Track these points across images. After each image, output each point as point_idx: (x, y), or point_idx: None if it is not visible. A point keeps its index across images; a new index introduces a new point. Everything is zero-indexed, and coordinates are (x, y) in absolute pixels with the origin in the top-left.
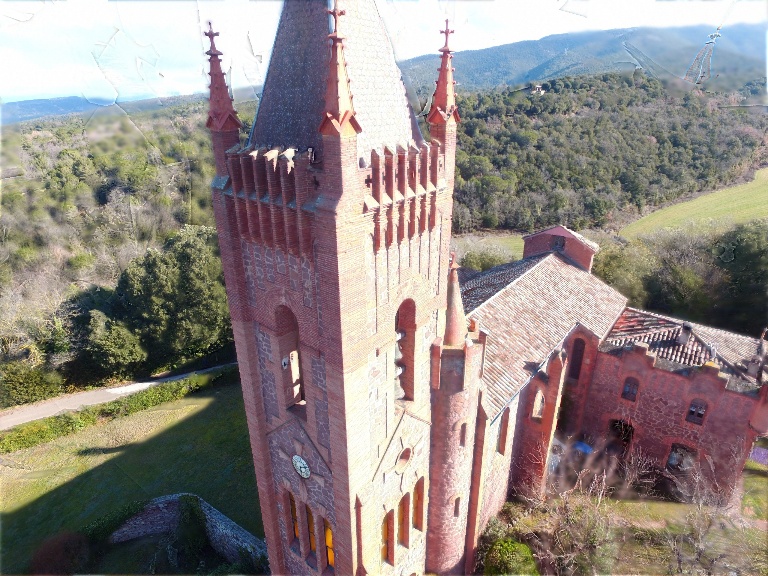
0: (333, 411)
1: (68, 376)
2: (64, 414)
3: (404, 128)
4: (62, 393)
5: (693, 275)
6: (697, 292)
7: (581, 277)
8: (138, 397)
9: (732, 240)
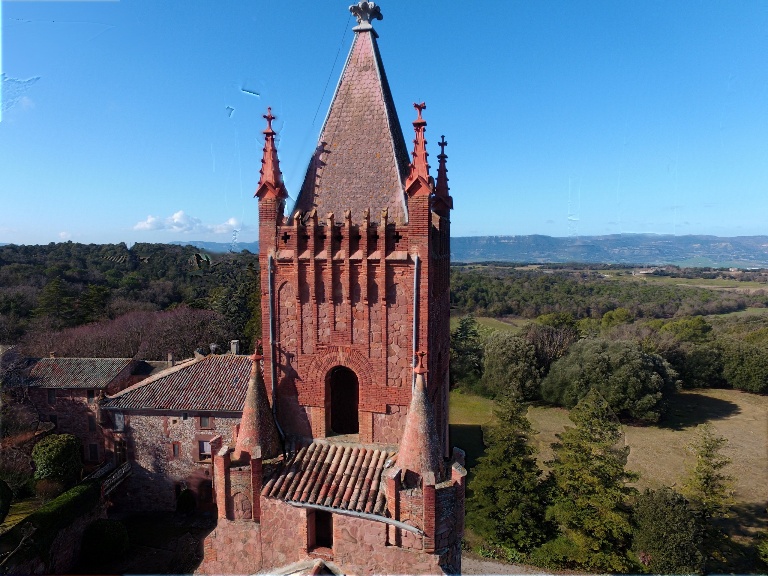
0: None
1: None
2: None
3: None
4: None
5: None
6: None
7: None
8: None
9: None
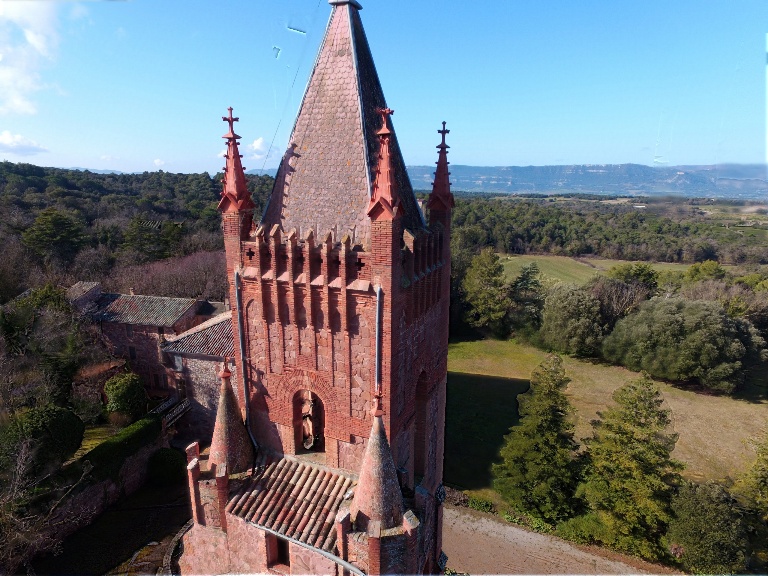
0: None
1: None
2: None
3: None
4: None
5: None
6: None
7: None
8: None
9: None
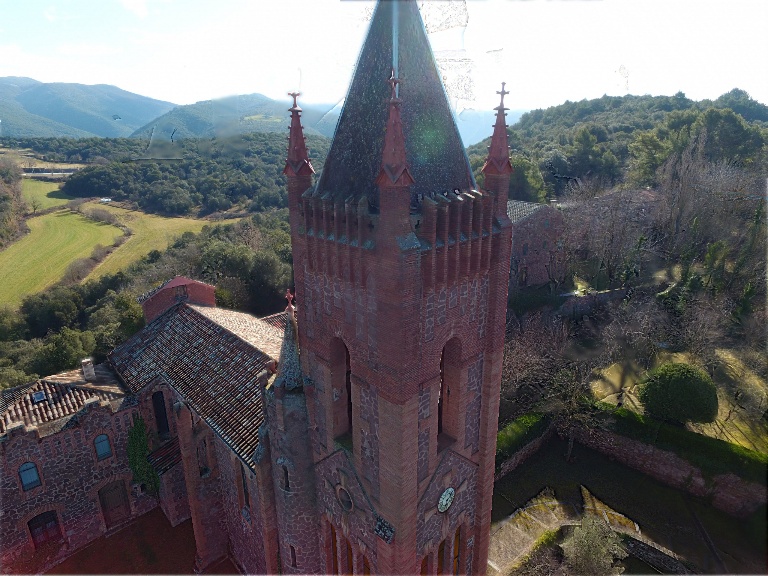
0: (493, 391)
1: None
2: None
3: None
4: None
5: (224, 290)
6: (236, 300)
7: (221, 312)
8: None
9: (208, 260)
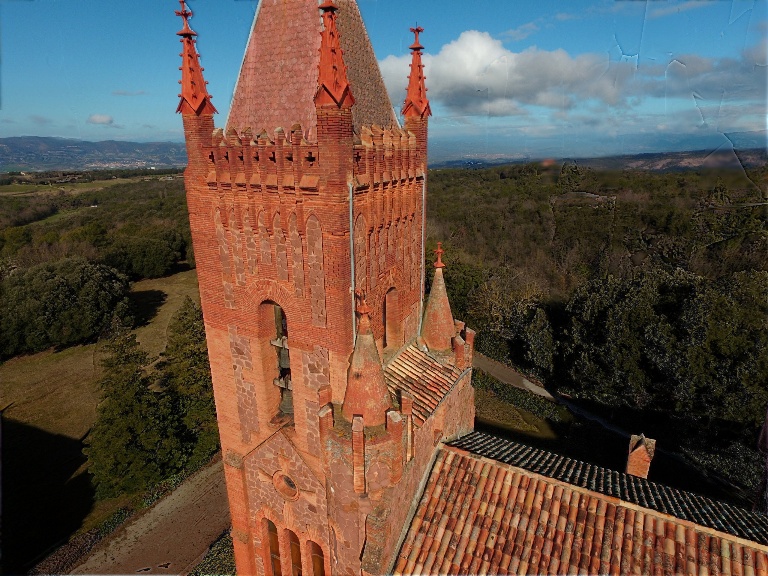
0: None
1: (511, 352)
2: (477, 370)
3: (308, 113)
4: (505, 362)
5: None
6: None
7: None
8: (516, 392)
9: None
